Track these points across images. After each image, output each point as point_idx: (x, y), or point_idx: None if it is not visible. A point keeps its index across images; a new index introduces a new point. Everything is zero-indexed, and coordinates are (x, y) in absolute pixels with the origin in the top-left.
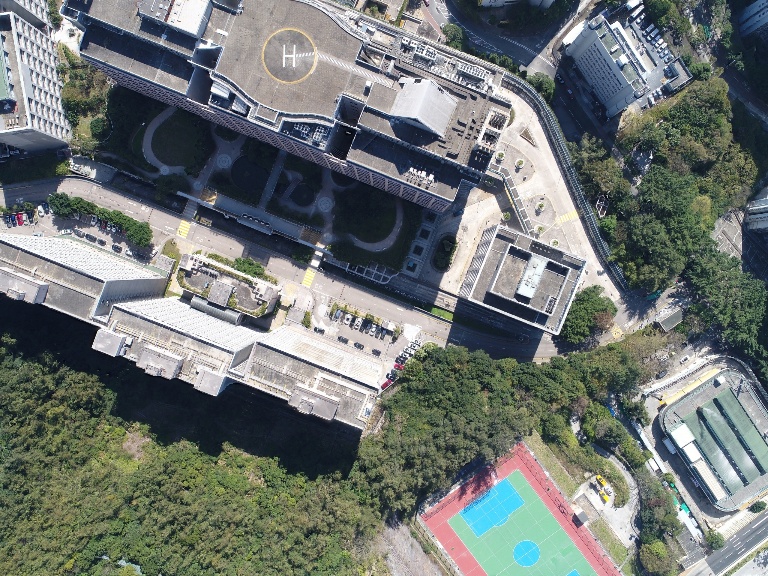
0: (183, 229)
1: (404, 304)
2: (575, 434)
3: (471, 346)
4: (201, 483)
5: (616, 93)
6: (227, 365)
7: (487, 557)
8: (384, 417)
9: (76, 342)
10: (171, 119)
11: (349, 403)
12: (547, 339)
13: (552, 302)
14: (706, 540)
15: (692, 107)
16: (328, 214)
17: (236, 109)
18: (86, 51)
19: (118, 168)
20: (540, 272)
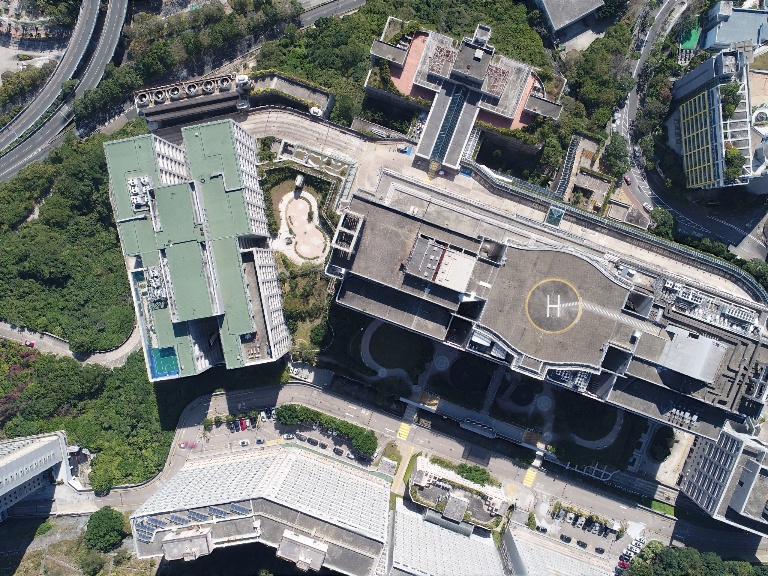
0: (403, 431)
1: (627, 502)
2: None
3: (695, 541)
4: None
5: None
6: None
7: None
8: None
9: None
10: (388, 323)
11: None
12: None
13: None
14: None
15: None
16: (547, 413)
17: (496, 355)
18: (343, 300)
19: (339, 374)
20: None
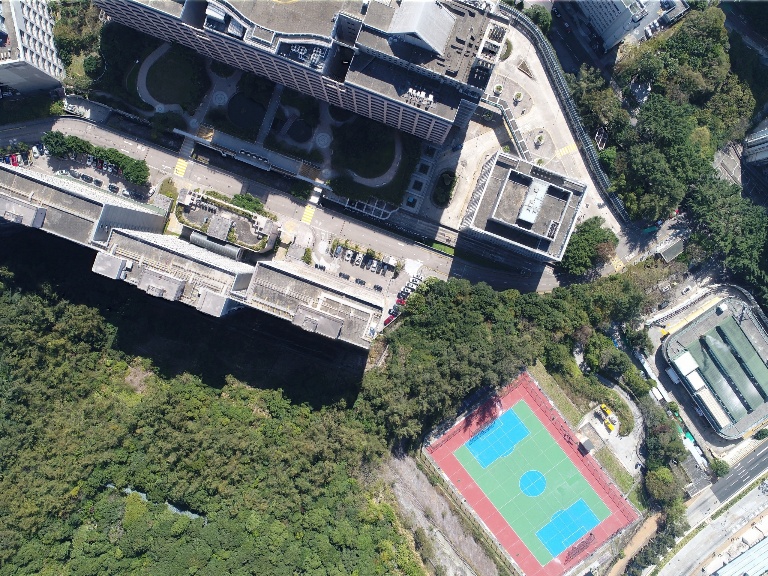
0: (180, 168)
1: (405, 239)
2: (579, 365)
3: (473, 280)
4: (205, 414)
5: (613, 21)
6: (229, 287)
7: (493, 488)
8: (387, 351)
9: (75, 278)
10: (165, 56)
11: (353, 323)
12: (549, 273)
13: (554, 226)
14: (711, 468)
15: (689, 36)
16: (326, 150)
17: (232, 32)
18: None
19: (113, 106)
20: (541, 196)
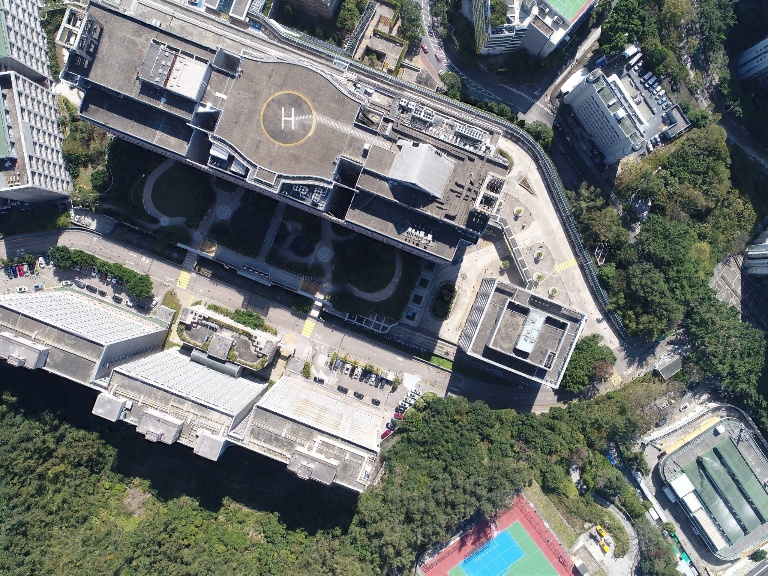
0: (183, 280)
1: (403, 354)
2: (575, 483)
3: (470, 395)
4: (201, 540)
5: (614, 144)
6: (227, 428)
7: None
8: (384, 468)
9: (77, 398)
10: (171, 170)
11: (348, 466)
12: (546, 387)
13: (551, 357)
14: None
15: (690, 155)
16: (327, 264)
17: (235, 170)
18: (86, 113)
19: (118, 220)
20: (539, 327)
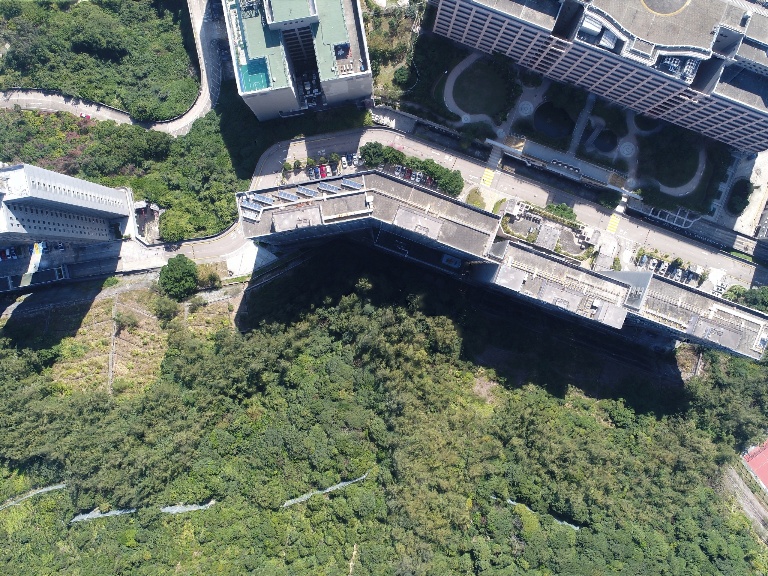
0: (487, 178)
1: (709, 248)
2: None
3: None
4: (559, 424)
5: None
6: (622, 299)
7: None
8: (702, 360)
9: (415, 289)
10: (472, 67)
11: (743, 334)
12: None
13: None
14: None
15: None
16: (631, 159)
17: (605, 44)
18: None
19: (424, 117)
20: None
